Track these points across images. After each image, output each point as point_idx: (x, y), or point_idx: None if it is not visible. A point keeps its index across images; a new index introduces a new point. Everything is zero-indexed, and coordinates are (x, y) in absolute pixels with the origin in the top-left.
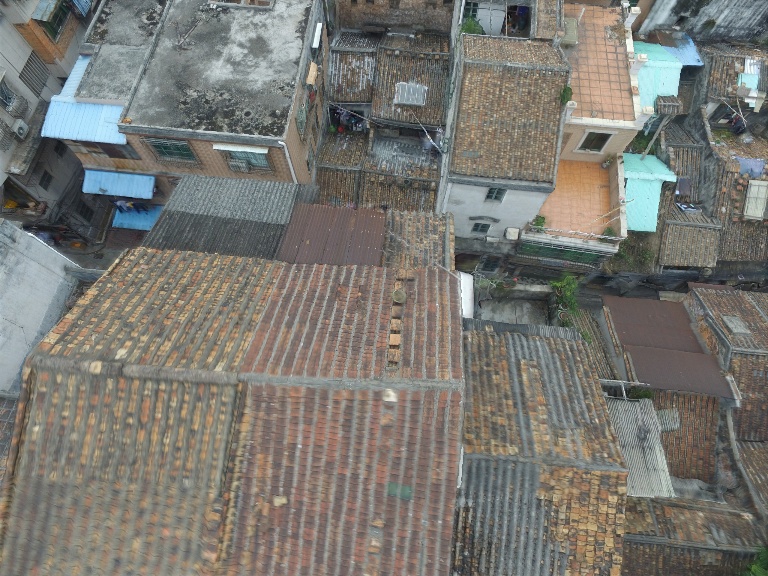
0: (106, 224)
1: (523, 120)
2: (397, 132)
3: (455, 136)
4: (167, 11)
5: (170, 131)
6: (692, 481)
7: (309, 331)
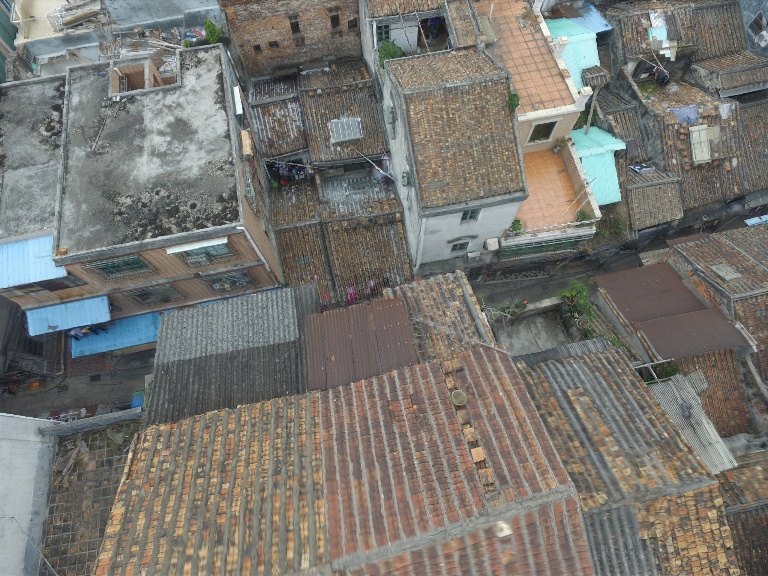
0: (61, 351)
1: (478, 137)
2: (342, 169)
3: (416, 171)
4: (66, 117)
5: (114, 249)
6: (739, 437)
7: (382, 475)
